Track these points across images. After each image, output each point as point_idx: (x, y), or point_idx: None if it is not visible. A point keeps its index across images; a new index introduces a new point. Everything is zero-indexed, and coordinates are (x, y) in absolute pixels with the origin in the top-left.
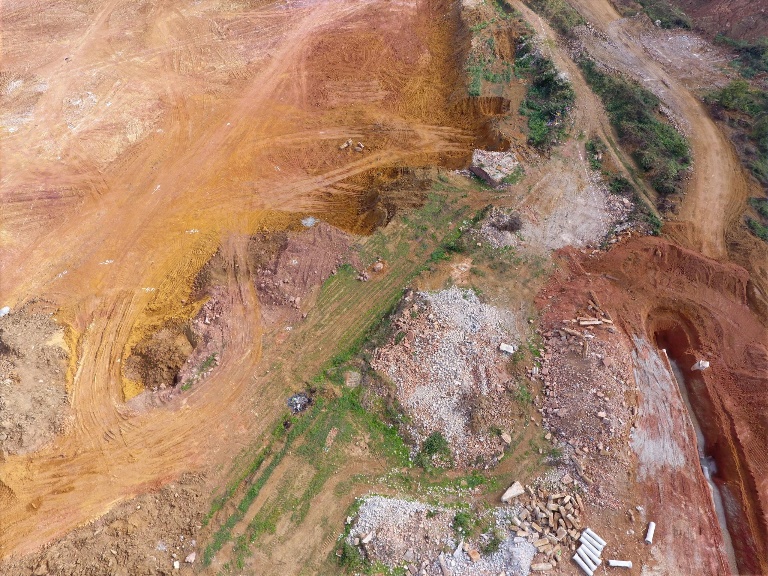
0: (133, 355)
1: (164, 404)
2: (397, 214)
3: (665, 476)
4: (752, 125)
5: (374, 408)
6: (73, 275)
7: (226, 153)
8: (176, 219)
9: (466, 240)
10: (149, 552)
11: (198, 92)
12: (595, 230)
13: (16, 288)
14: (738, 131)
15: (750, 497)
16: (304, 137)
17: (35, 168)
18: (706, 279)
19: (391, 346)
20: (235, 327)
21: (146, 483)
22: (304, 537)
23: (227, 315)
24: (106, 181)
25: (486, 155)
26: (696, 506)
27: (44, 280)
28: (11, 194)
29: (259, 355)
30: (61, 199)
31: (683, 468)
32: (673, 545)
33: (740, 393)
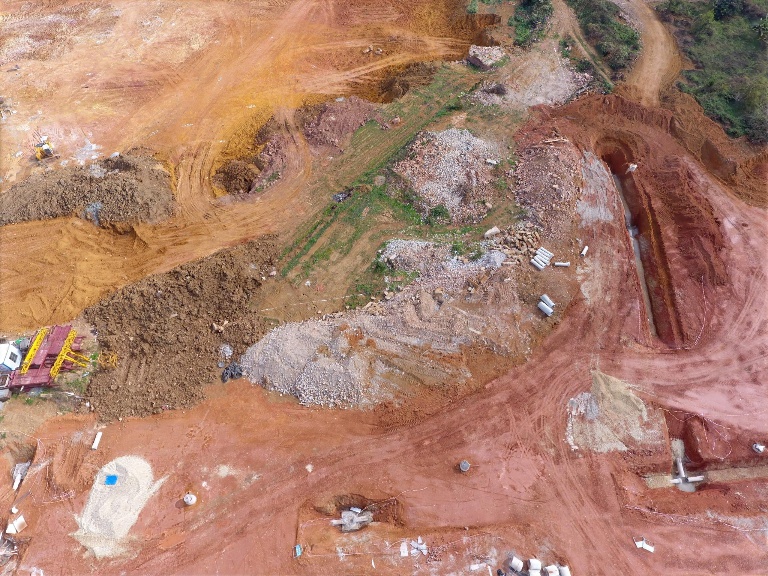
0: (218, 173)
1: (244, 200)
2: (410, 89)
3: (598, 225)
4: (692, 24)
5: (395, 195)
6: (163, 133)
7: (272, 56)
8: (237, 98)
9: (463, 101)
10: (246, 267)
11: (245, 15)
12: (562, 94)
13: (122, 141)
14: (680, 28)
15: (656, 237)
16: (334, 46)
17: (122, 67)
18: (641, 118)
19: (407, 161)
20: (291, 157)
21: (237, 240)
22: (349, 261)
23: (285, 150)
24: (179, 75)
25: (480, 48)
26: (618, 240)
27: (142, 136)
28: (106, 84)
29: (310, 173)
30: (146, 87)
31: (611, 222)
32: (599, 258)
33: (658, 183)
